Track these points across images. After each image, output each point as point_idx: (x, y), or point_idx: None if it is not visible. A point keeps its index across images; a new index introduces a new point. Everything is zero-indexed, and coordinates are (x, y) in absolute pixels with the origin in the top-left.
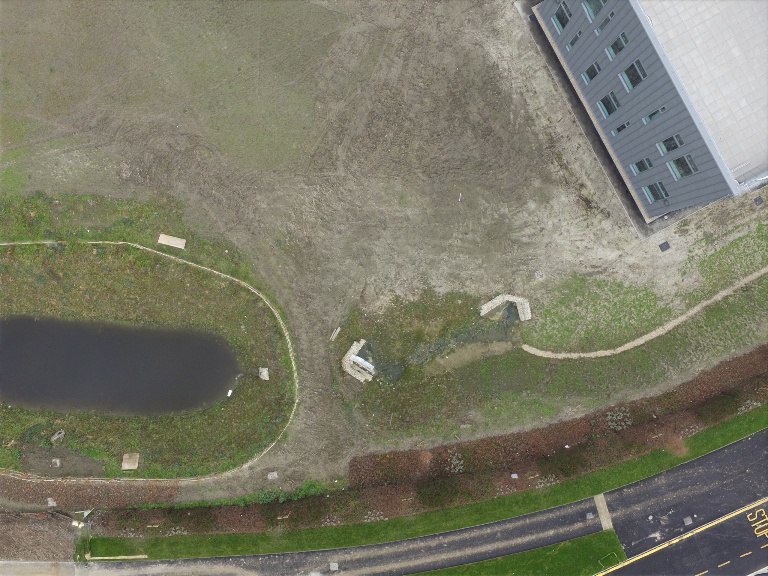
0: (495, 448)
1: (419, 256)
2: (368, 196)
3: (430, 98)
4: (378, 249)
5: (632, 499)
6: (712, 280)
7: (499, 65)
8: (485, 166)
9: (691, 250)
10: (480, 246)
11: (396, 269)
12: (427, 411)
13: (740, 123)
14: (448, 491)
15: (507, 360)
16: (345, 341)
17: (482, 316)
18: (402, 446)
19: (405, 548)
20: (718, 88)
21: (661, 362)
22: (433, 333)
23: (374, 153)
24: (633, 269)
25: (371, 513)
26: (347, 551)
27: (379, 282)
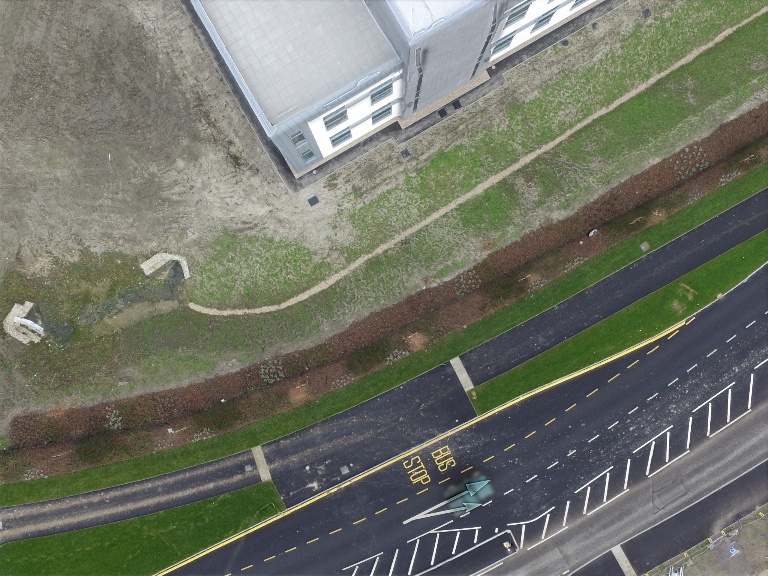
0: (153, 404)
1: (70, 217)
2: (17, 159)
3: (75, 60)
4: (29, 211)
5: (289, 450)
6: (368, 233)
7: (144, 25)
8: (133, 126)
9: (340, 204)
10: (131, 205)
11: (49, 230)
12: (88, 370)
13: (287, 68)
14: (102, 447)
15: (172, 318)
16: (4, 303)
17: (148, 276)
18: (62, 405)
19: (68, 505)
20: (265, 34)
21: (318, 315)
22: (100, 294)
23: (21, 116)
24: (283, 224)
25: (30, 471)
26: (10, 510)
27: (34, 244)
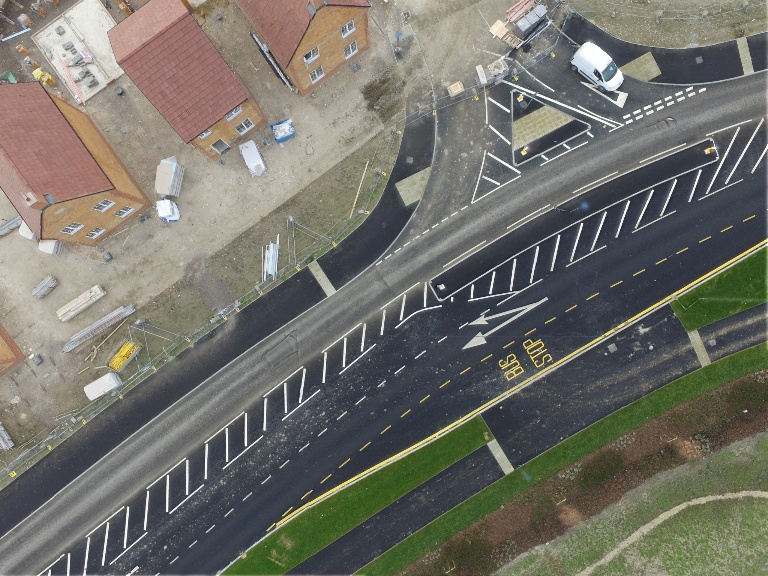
0: None
1: None
2: None
3: None
4: None
5: (672, 365)
6: None
7: None
8: None
9: None
10: None
11: None
12: None
13: None
14: None
15: None
16: None
17: None
18: None
19: None
20: None
21: None
22: None
23: None
24: None
25: None
26: None
27: None
